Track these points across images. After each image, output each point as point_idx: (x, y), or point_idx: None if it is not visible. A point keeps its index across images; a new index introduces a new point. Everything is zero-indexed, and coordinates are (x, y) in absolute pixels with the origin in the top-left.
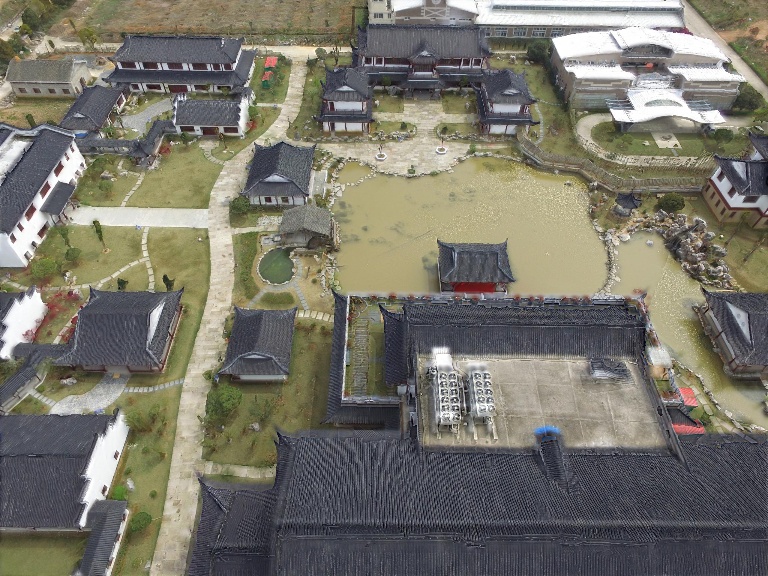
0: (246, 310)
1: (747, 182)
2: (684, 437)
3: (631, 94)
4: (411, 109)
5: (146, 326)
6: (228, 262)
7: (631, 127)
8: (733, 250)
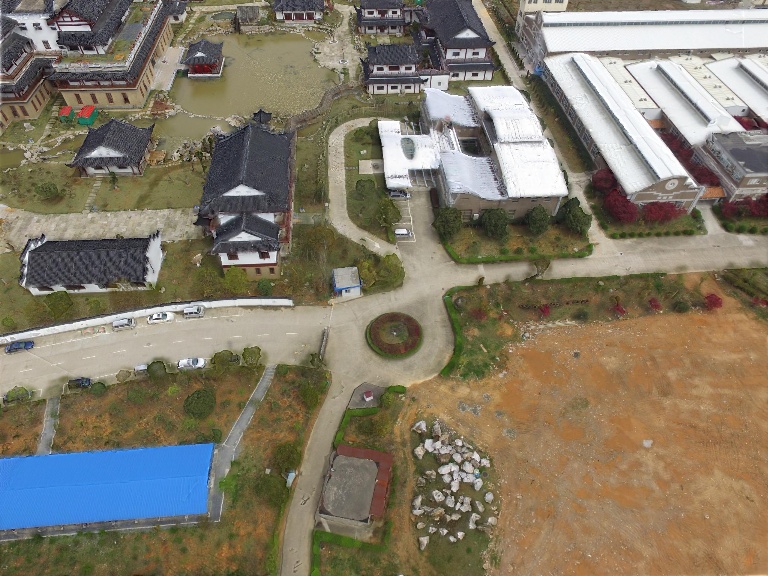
0: (186, 4)
1: None
2: None
3: None
4: None
5: None
6: (233, 8)
7: None
8: (207, 168)
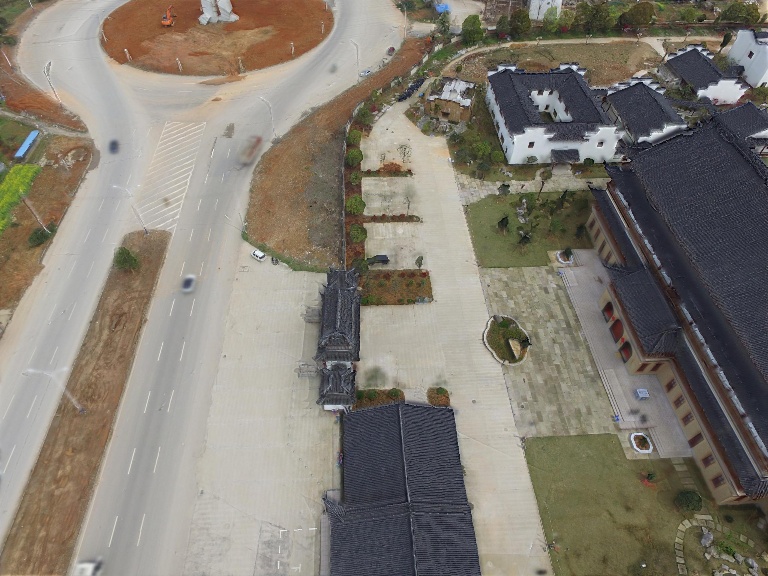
0: None
1: None
2: None
3: None
4: None
5: (763, 130)
6: None
7: None
8: None
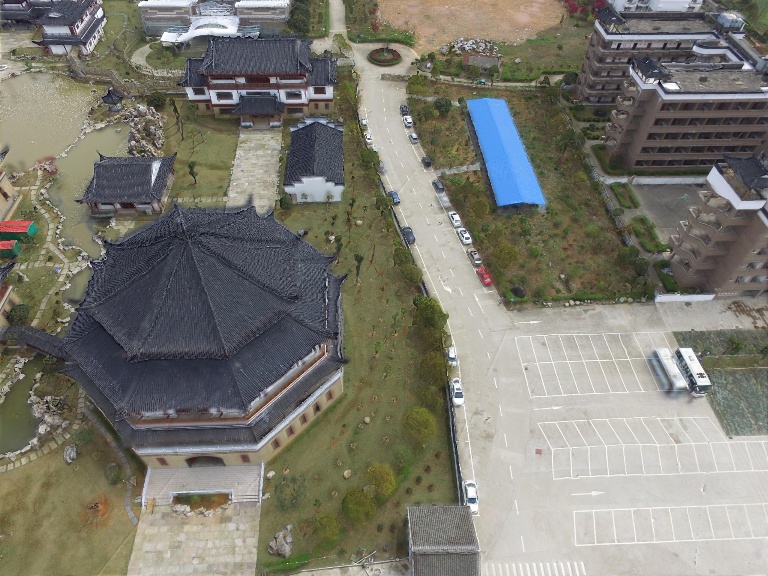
0: None
1: (186, 76)
2: (1, 253)
3: (194, 21)
4: (2, 37)
5: None
6: None
7: (185, 48)
8: None
